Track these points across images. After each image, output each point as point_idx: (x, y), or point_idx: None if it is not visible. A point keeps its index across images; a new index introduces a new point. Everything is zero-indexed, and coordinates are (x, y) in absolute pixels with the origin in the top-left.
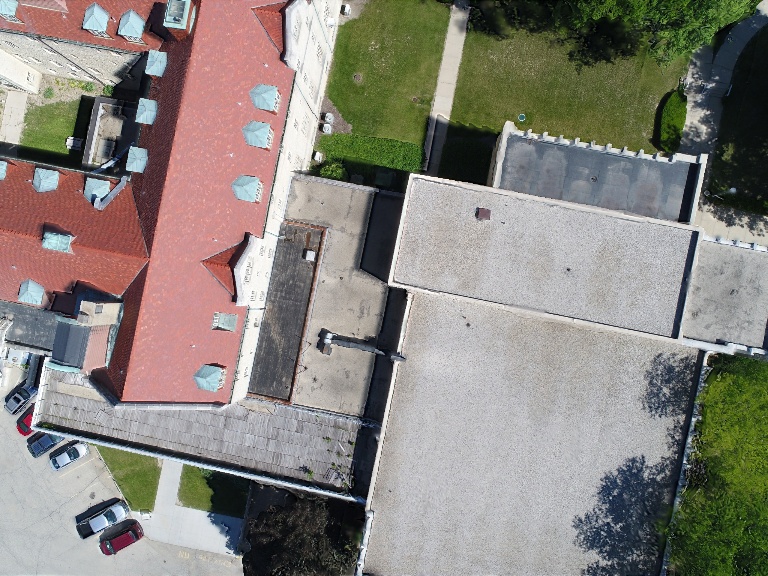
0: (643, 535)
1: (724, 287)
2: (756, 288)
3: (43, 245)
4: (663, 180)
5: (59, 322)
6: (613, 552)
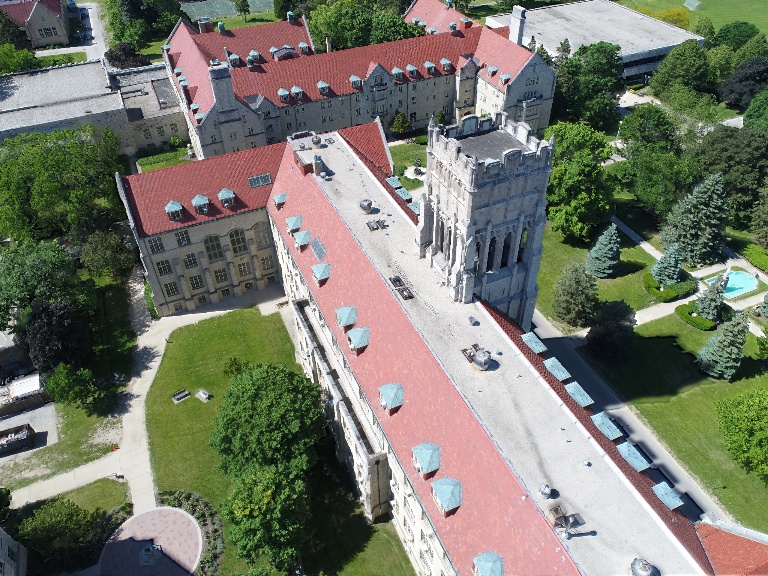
0: None
1: None
2: None
3: None
4: None
5: None
6: (5, 87)
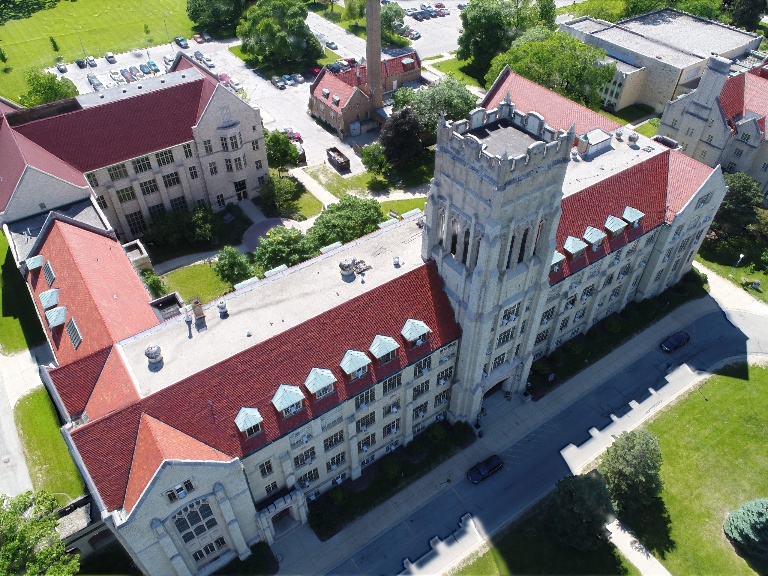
0: None
1: None
2: None
3: None
4: None
5: None
6: None
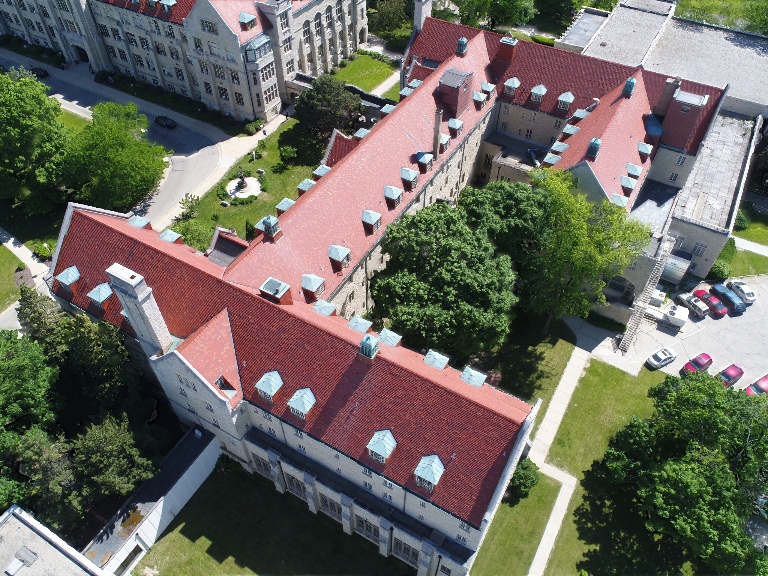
0: (763, 43)
1: (644, 6)
2: (645, 1)
3: (634, 82)
4: (590, 18)
5: (677, 97)
6: None
